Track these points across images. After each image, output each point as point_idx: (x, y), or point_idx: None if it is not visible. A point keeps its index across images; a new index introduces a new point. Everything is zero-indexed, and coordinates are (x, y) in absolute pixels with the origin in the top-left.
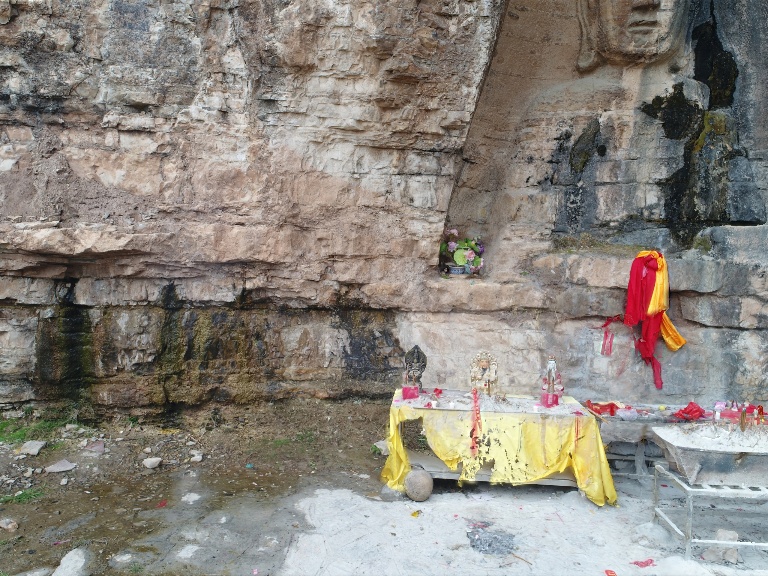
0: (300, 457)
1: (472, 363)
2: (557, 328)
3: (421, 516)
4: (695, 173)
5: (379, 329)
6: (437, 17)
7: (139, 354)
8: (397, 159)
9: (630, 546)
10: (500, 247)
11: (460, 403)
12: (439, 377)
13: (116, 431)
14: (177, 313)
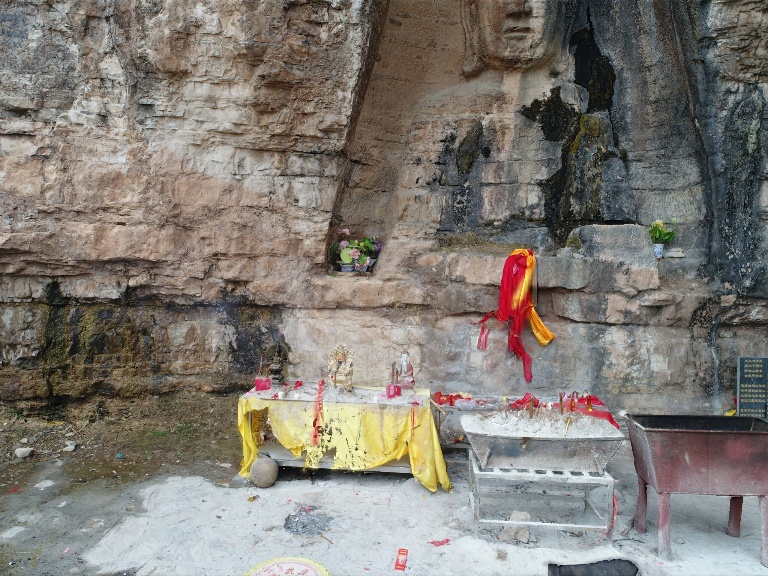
0: (171, 447)
1: (330, 356)
2: (438, 324)
3: (255, 501)
4: (571, 174)
5: (266, 325)
6: (307, 24)
7: (23, 349)
8: (278, 161)
9: (439, 527)
10: (387, 246)
11: (306, 394)
12: None
13: (1, 423)
14: (62, 309)
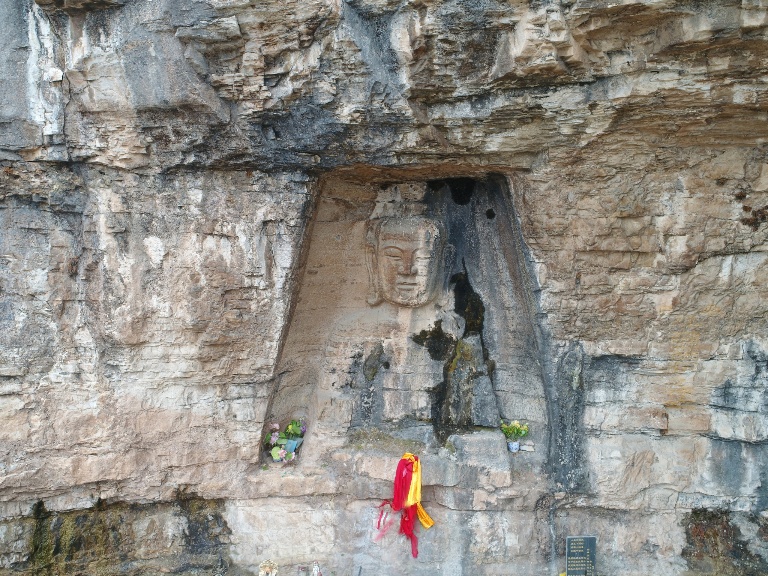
0: None
1: (260, 568)
2: (348, 507)
3: None
4: (450, 388)
5: (212, 513)
6: (240, 301)
7: (16, 556)
8: (220, 391)
9: None
10: (309, 441)
11: None
12: (257, 549)
13: None
14: (46, 520)
